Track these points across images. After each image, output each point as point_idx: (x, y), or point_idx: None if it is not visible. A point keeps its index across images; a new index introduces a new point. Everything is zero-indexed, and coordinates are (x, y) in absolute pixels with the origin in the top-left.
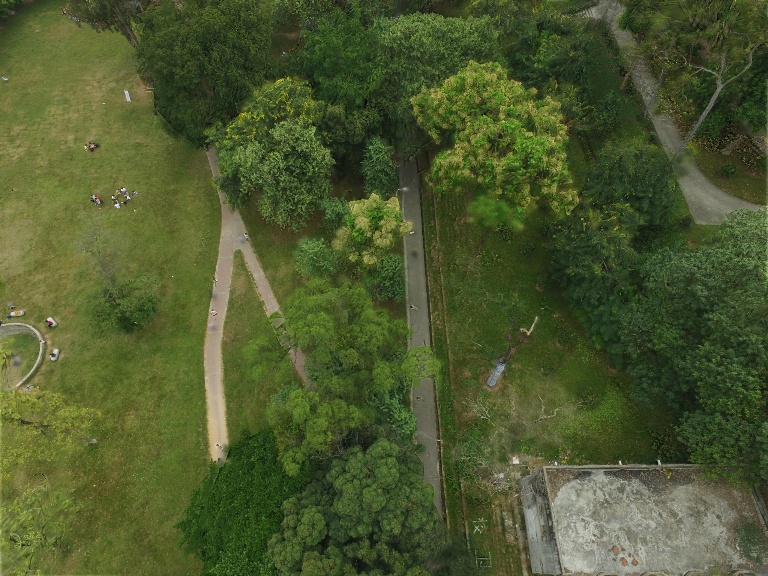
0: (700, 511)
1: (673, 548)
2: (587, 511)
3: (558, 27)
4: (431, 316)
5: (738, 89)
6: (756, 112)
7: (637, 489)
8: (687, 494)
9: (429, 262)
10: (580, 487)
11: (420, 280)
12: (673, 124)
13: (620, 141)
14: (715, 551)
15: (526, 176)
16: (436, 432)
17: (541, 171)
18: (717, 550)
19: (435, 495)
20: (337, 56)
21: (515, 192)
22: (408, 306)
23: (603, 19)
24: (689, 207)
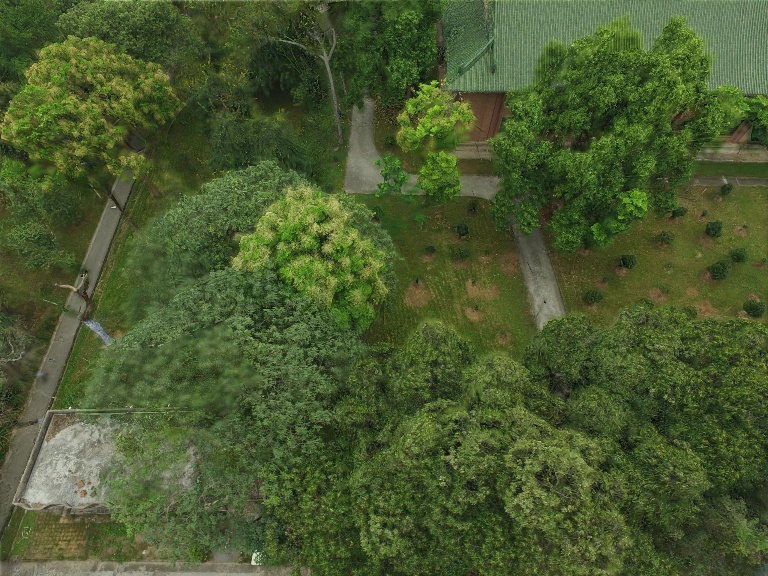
0: (181, 449)
1: (137, 481)
2: (75, 450)
3: (278, 9)
4: (98, 284)
5: (348, 61)
6: (365, 83)
7: (133, 430)
8: (178, 434)
9: (117, 234)
10: (81, 429)
11: (101, 251)
12: (373, 100)
13: (321, 117)
14: (175, 484)
15: (43, 139)
16: (54, 390)
17: (58, 134)
18: (177, 483)
19: (27, 447)
20: (5, 36)
21: (52, 156)
22: (79, 275)
23: (354, 2)
24: (346, 177)
